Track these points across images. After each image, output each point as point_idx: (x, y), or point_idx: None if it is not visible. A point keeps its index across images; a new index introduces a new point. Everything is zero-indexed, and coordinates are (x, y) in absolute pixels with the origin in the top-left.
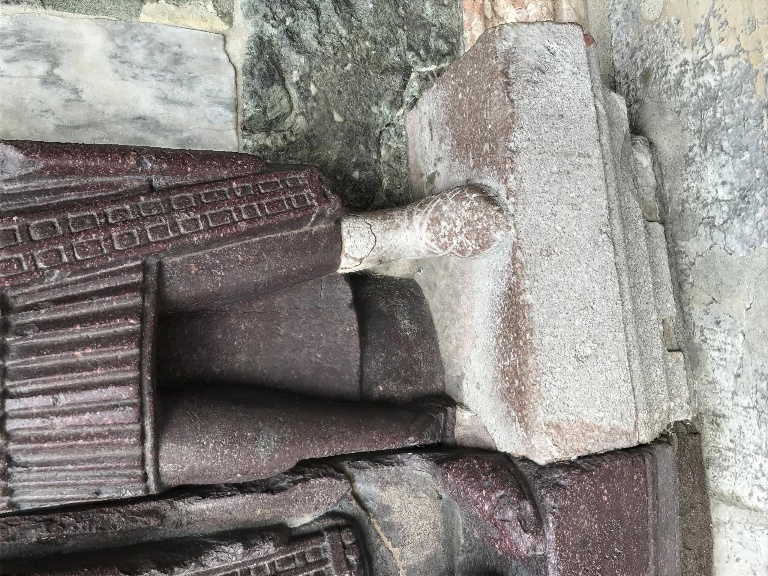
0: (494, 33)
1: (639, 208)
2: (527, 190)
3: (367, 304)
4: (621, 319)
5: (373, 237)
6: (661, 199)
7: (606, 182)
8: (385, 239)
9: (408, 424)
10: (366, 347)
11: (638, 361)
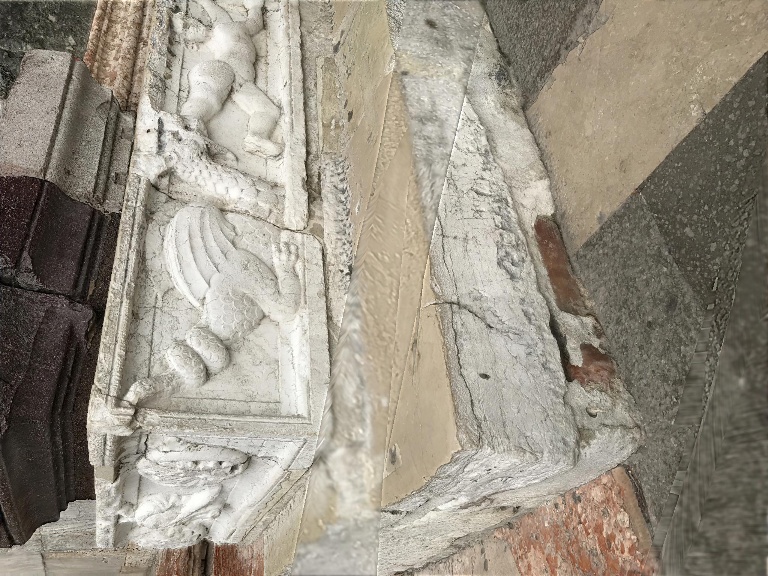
0: (27, 52)
1: (103, 124)
2: (18, 94)
3: None
4: (50, 137)
5: None
6: None
7: (66, 99)
8: None
9: None
10: None
11: (57, 154)
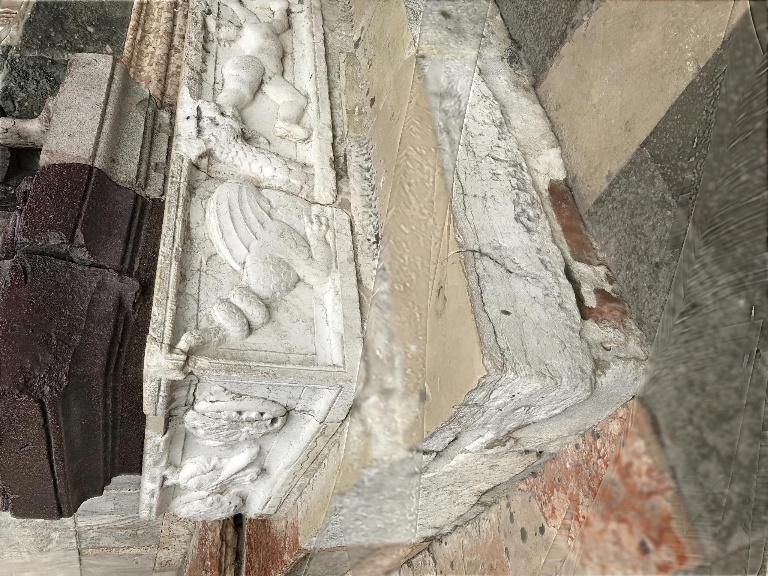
0: (72, 55)
1: (143, 119)
2: (66, 92)
3: (26, 171)
4: (96, 128)
5: (13, 122)
6: (173, 129)
7: (109, 96)
8: (20, 124)
9: (12, 185)
10: (14, 177)
11: None
